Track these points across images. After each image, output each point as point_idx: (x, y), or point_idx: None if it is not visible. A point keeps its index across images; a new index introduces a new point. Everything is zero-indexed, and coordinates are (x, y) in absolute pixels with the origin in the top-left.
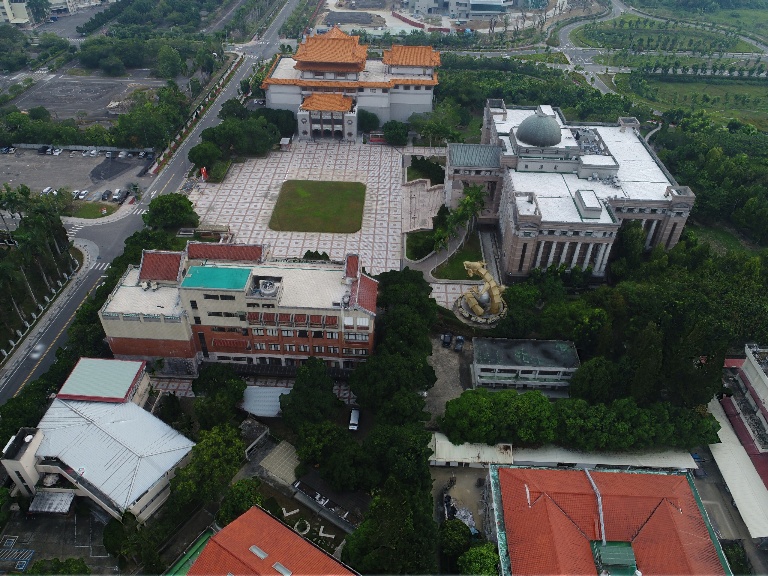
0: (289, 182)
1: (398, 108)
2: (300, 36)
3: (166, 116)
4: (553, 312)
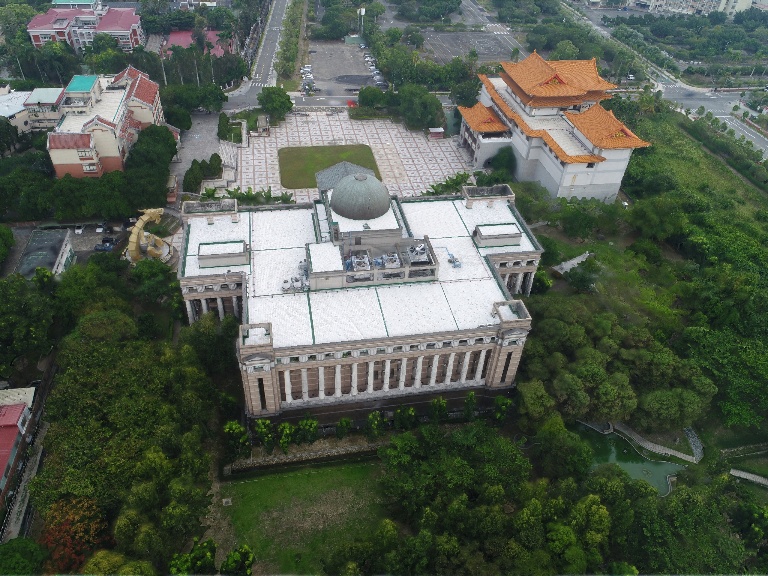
0: (365, 146)
1: (541, 170)
2: (759, 108)
3: (435, 72)
4: None
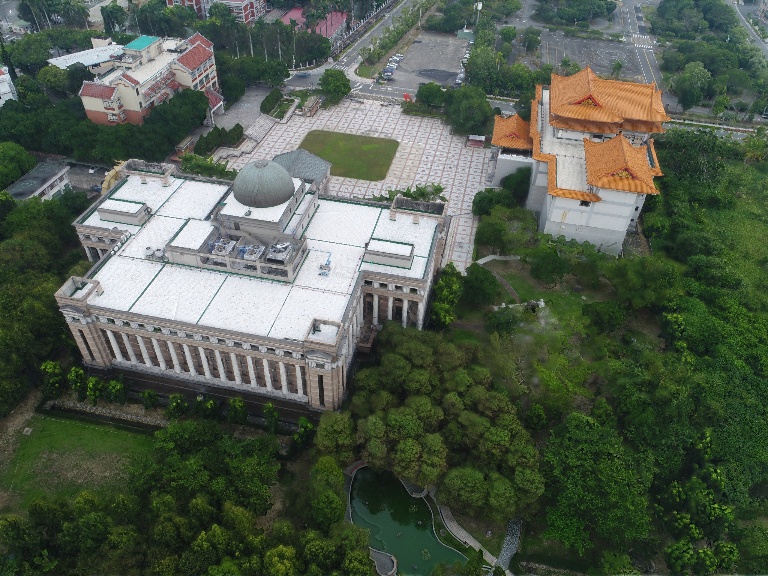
0: (394, 142)
1: None
2: None
3: (518, 78)
4: (49, 201)
